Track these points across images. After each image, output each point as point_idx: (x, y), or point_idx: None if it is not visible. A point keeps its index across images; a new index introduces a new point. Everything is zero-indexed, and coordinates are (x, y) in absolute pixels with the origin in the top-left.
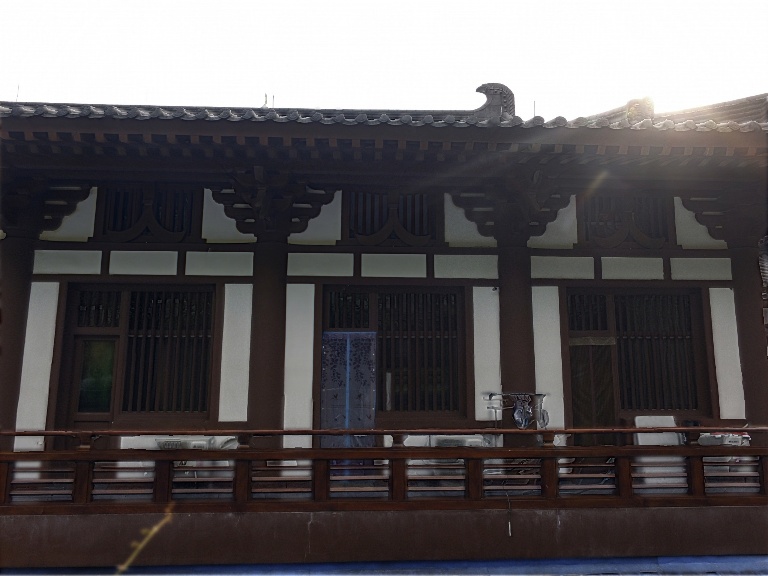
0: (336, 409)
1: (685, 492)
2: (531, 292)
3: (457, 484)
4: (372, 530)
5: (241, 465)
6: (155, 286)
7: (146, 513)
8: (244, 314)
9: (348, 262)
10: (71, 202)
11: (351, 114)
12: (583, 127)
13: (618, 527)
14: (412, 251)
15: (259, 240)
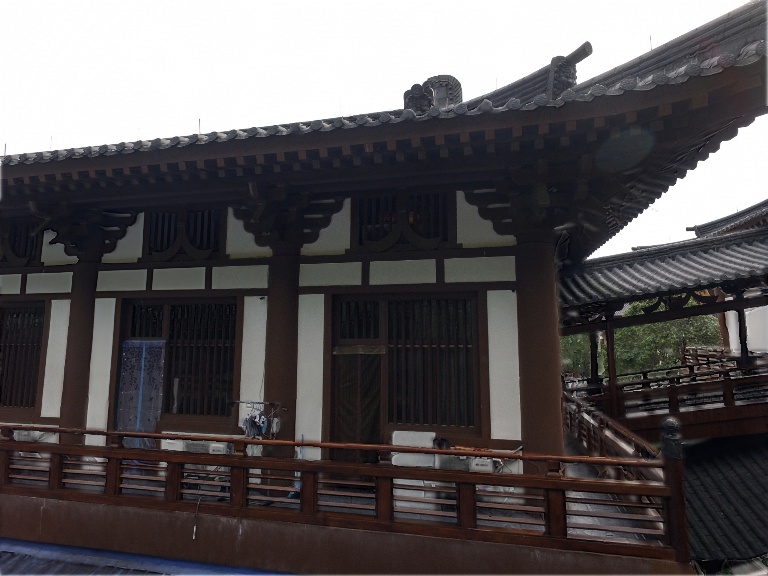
0: (131, 410)
1: (375, 514)
2: (298, 300)
3: (160, 485)
4: (86, 519)
5: (1, 454)
6: (8, 303)
7: None
8: (63, 326)
9: (142, 277)
10: None
11: None
12: (231, 139)
13: (295, 543)
14: (194, 265)
15: None
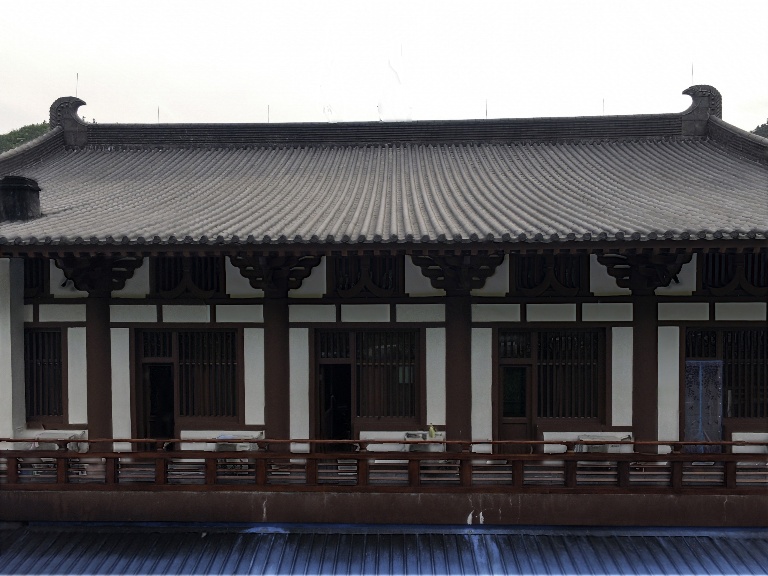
0: (692, 417)
1: None
2: None
3: None
4: (767, 507)
5: (677, 465)
6: (558, 329)
7: (616, 494)
8: (627, 350)
9: (705, 309)
10: (493, 267)
11: (566, 122)
12: None
13: None
14: (755, 300)
15: (635, 293)
